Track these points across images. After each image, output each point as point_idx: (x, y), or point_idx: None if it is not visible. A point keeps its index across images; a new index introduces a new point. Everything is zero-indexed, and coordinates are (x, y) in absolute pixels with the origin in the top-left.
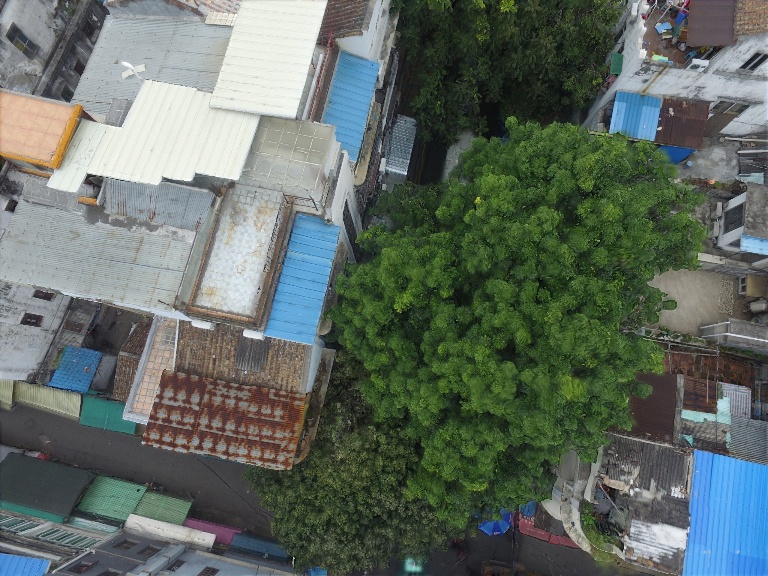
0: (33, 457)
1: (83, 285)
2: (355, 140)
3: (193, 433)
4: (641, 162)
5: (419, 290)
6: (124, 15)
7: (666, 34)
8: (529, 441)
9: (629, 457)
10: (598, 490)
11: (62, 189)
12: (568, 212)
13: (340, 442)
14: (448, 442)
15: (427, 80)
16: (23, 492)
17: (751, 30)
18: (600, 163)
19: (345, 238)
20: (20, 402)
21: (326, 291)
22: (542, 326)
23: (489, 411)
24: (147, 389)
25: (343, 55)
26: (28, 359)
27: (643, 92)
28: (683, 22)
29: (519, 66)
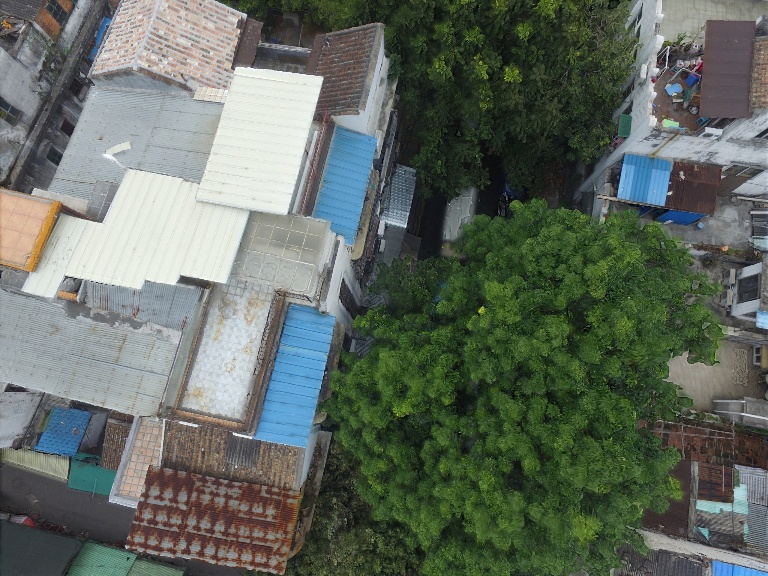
0: (19, 524)
1: (62, 386)
2: (351, 222)
3: (180, 535)
4: (654, 248)
5: (419, 399)
6: (109, 87)
7: (677, 97)
8: (537, 565)
9: (643, 568)
10: None
11: (38, 294)
12: (578, 311)
13: (336, 543)
14: (450, 562)
15: (427, 138)
16: (7, 564)
17: (767, 103)
18: (613, 269)
19: (342, 313)
20: (7, 463)
21: (321, 385)
22: (551, 448)
23: (495, 544)
24: (135, 469)
25: (339, 130)
26: (13, 425)
27: (652, 155)
28: (695, 87)
29: (523, 129)
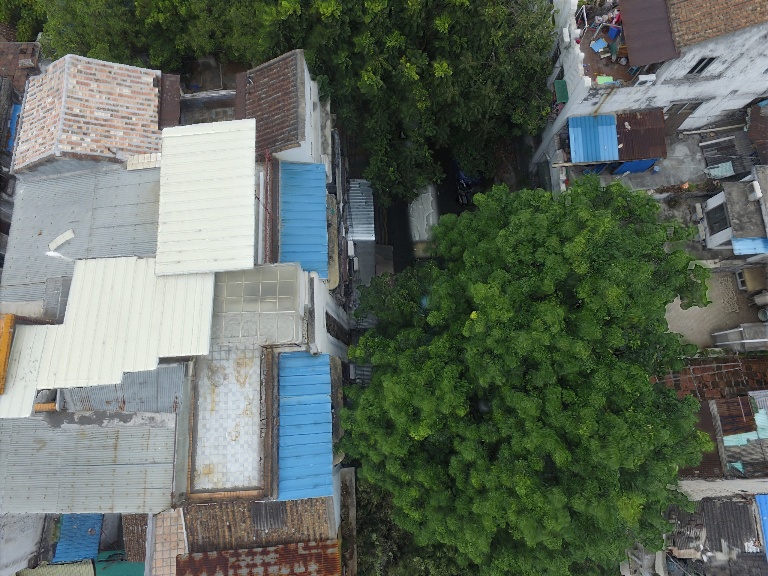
0: None
1: (64, 501)
2: (320, 255)
3: None
4: (622, 207)
5: (434, 418)
6: (36, 178)
7: (604, 52)
8: None
9: (692, 521)
10: (669, 563)
11: (13, 416)
12: (566, 289)
13: None
14: (506, 572)
15: (373, 148)
16: None
17: (692, 40)
18: (591, 242)
19: (333, 345)
20: None
21: None
22: (577, 434)
23: (547, 546)
24: (162, 559)
25: (284, 165)
26: (24, 545)
27: (595, 113)
28: (618, 39)
29: (465, 118)
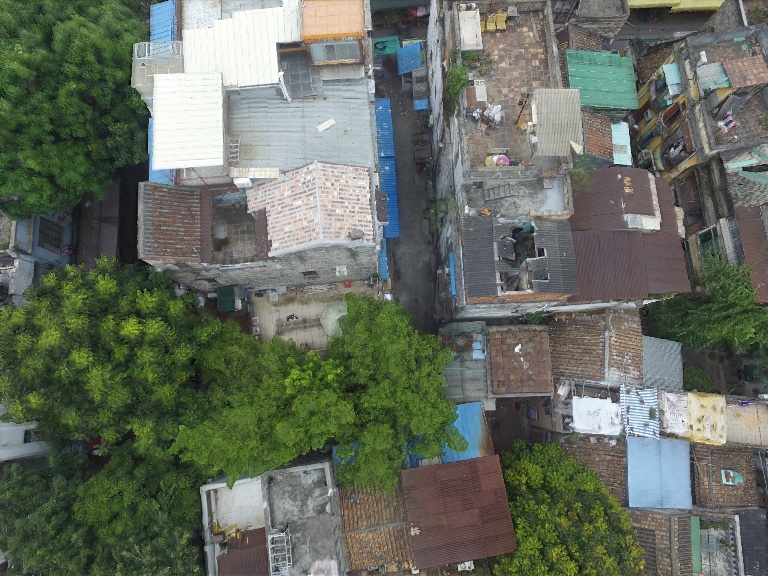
0: (414, 6)
1: None
2: None
3: None
4: None
5: None
6: None
7: None
8: None
9: None
10: None
11: None
12: None
13: None
14: None
15: None
16: None
17: None
18: None
19: None
20: None
21: None
22: None
23: None
24: None
25: None
26: None
27: None
28: None
29: None
